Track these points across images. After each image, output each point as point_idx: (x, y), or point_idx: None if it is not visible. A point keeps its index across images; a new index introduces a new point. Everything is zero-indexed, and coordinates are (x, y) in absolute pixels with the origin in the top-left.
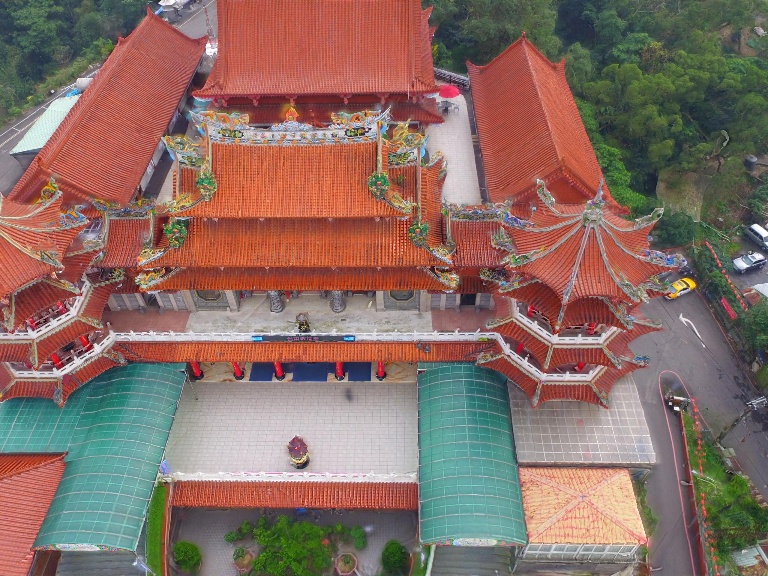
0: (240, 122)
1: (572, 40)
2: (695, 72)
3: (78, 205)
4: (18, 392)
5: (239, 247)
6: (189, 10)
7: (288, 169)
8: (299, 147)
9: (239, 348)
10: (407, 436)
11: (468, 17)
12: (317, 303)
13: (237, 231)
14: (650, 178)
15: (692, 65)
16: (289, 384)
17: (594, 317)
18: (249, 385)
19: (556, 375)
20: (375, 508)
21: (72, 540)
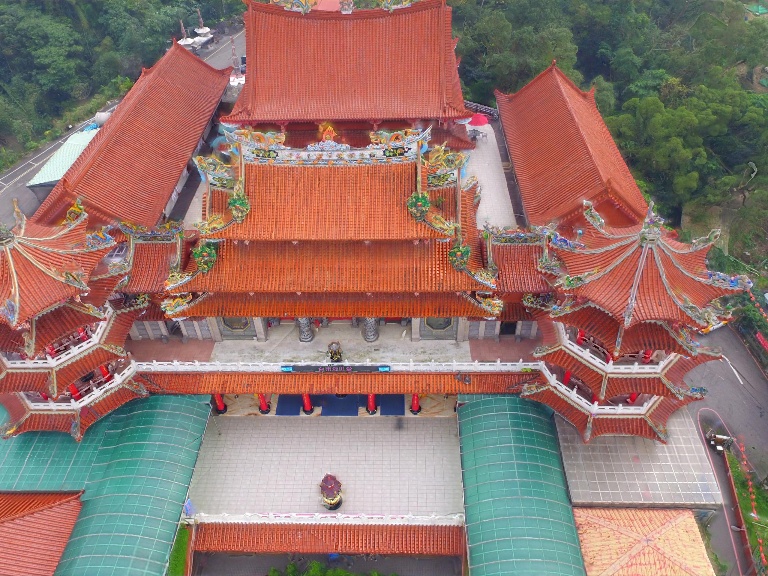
0: (275, 142)
1: (586, 78)
2: (717, 106)
3: (106, 226)
4: (33, 425)
5: (270, 271)
6: (207, 49)
7: (323, 190)
8: (335, 168)
9: (267, 379)
10: (446, 474)
11: (485, 55)
12: (348, 332)
13: (268, 255)
14: (674, 212)
15: (713, 99)
16: (318, 418)
17: (654, 343)
18: (275, 419)
19: (608, 407)
20: (412, 554)
21: None
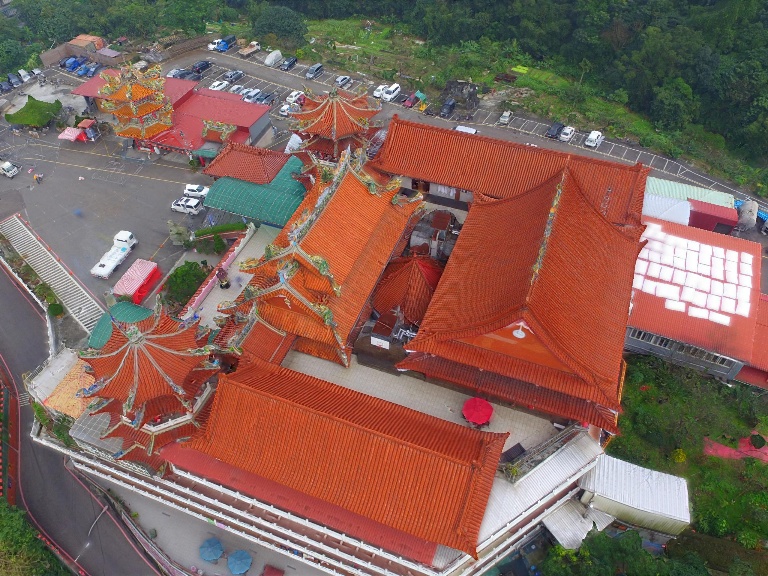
0: None
1: None
2: None
3: None
4: None
5: None
6: None
7: None
8: None
9: None
10: None
11: None
12: None
13: None
14: None
15: None
16: None
17: None
18: None
19: None
20: None
21: (216, 182)
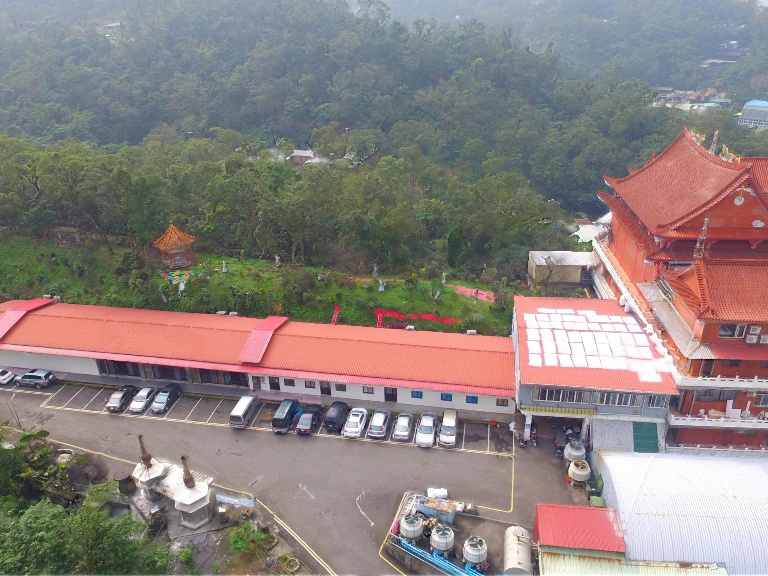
0: None
1: None
2: None
3: None
4: None
5: None
6: None
7: None
8: None
9: None
10: None
11: None
12: None
13: None
14: None
15: None
16: None
17: None
18: None
19: None
20: None
21: None
